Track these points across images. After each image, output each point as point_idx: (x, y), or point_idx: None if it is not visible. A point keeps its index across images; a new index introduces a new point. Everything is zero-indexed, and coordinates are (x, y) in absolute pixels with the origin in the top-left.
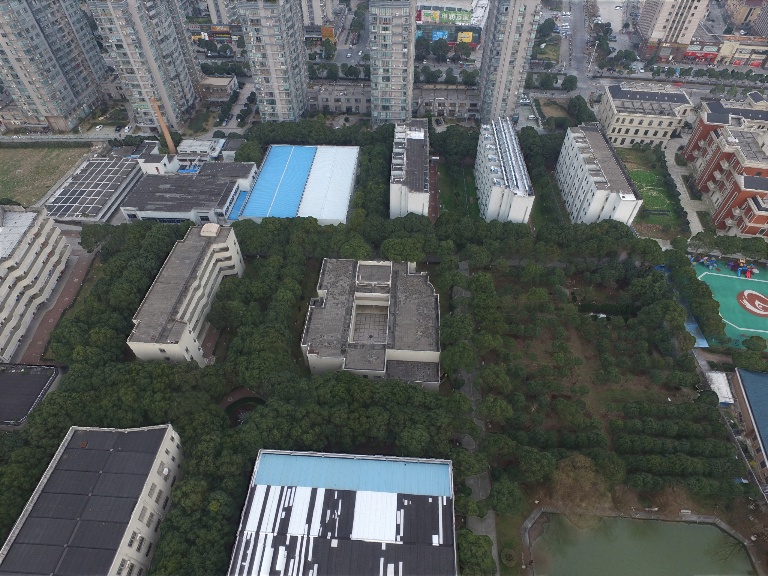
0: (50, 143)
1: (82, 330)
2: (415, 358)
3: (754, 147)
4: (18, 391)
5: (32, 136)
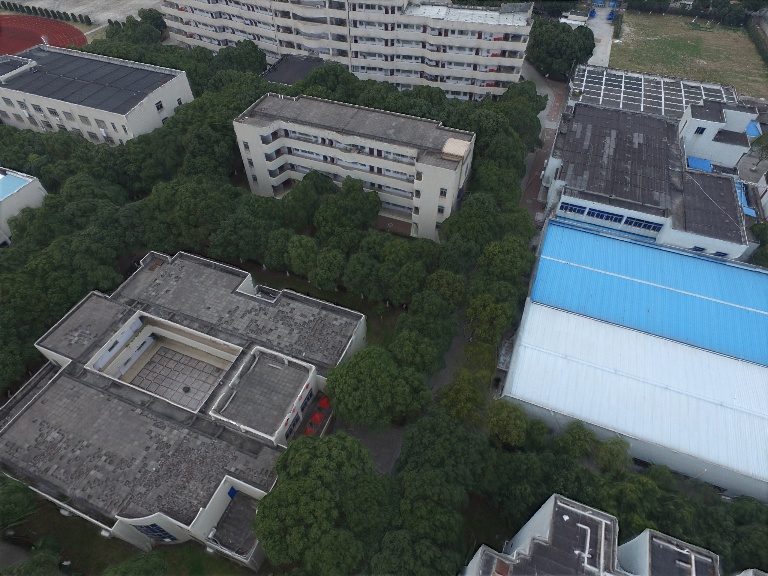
0: None
1: (327, 82)
2: None
3: None
4: (295, 76)
5: None
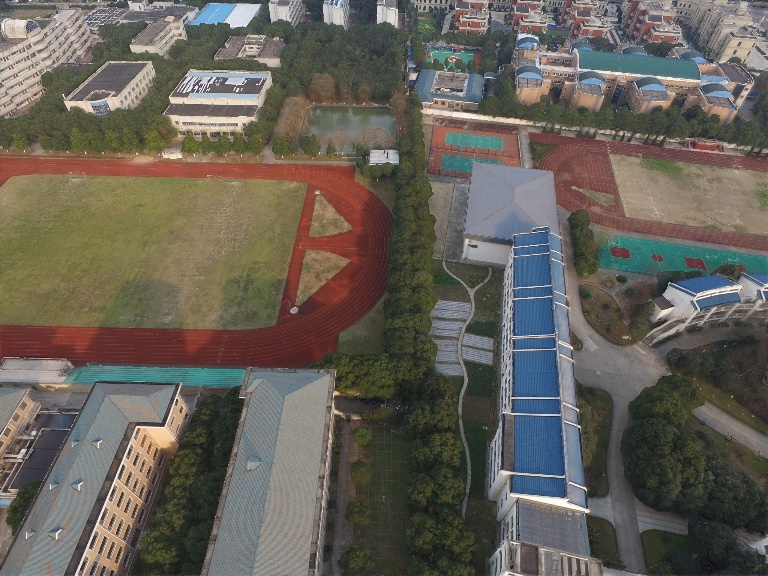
0: (69, 6)
1: None
2: (270, 65)
3: None
4: None
5: (57, 3)
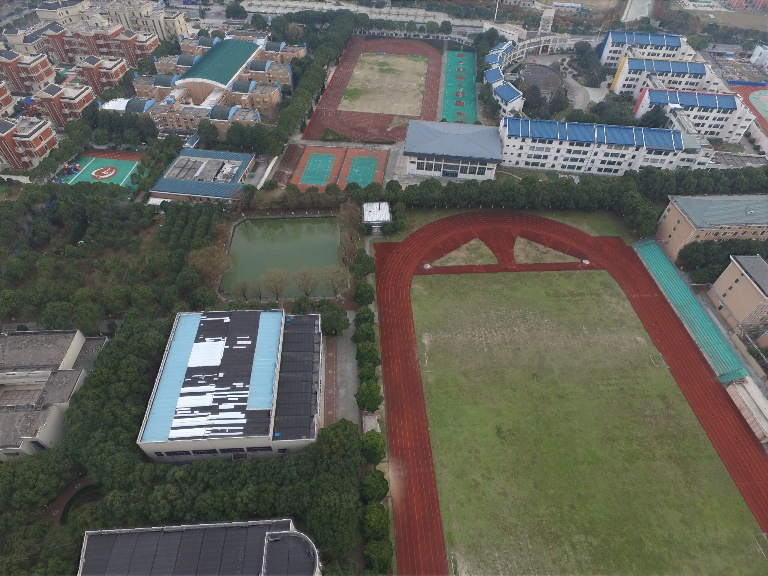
0: None
1: None
2: (75, 354)
3: None
4: None
5: None
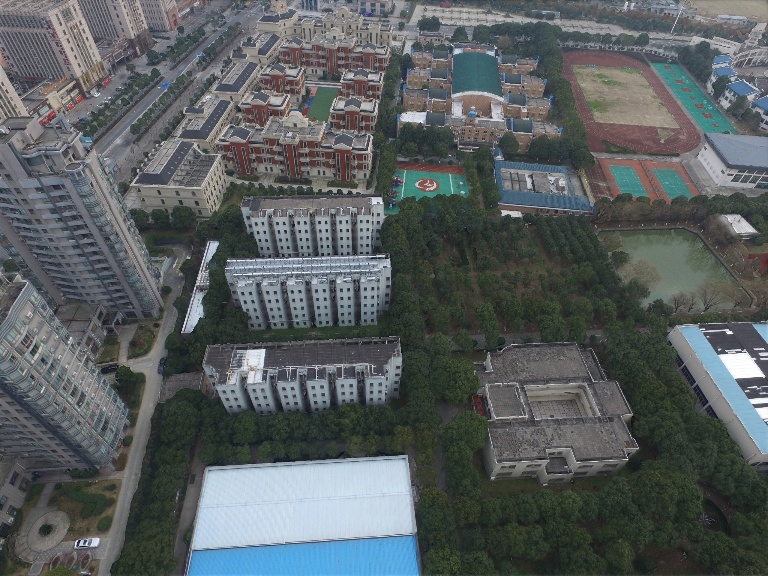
0: None
1: None
2: None
3: (294, 130)
4: None
5: None
